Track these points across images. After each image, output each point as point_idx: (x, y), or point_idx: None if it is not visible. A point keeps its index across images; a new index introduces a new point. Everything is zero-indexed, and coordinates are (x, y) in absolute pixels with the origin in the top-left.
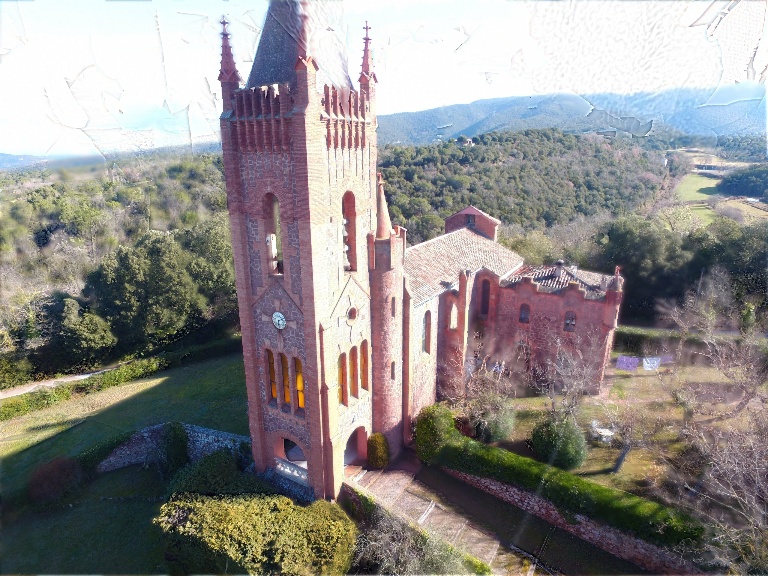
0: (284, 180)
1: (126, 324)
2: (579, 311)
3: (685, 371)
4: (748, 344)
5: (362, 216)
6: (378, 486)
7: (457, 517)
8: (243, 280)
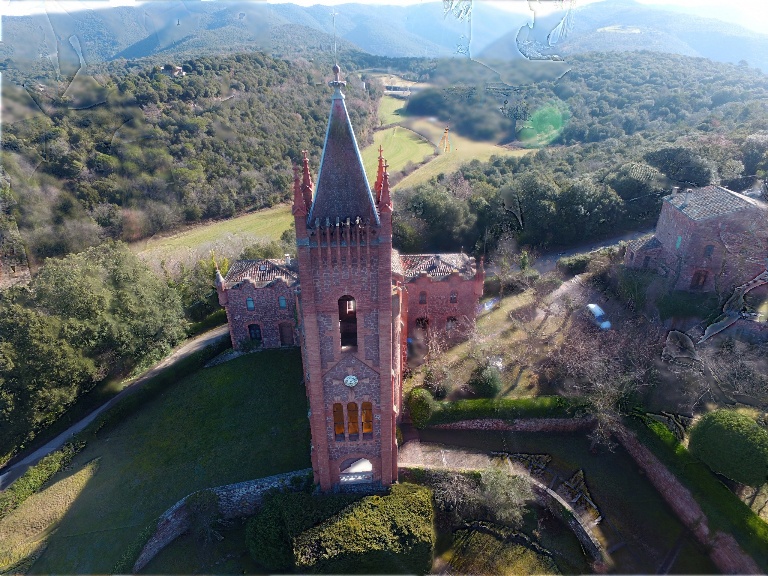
0: (362, 285)
1: (2, 424)
2: (459, 289)
3: (503, 303)
4: (526, 276)
5: None
6: (407, 458)
7: (459, 452)
8: (317, 361)
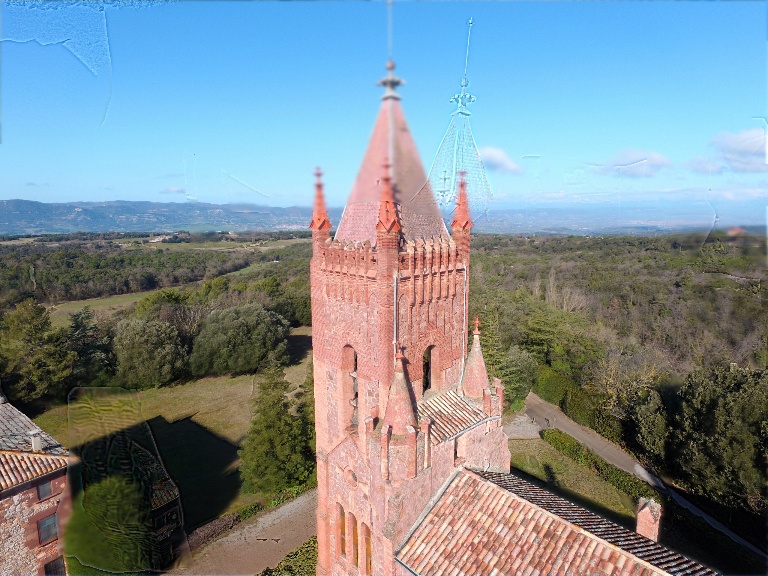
0: None
1: None
2: None
3: None
4: None
5: (366, 381)
6: None
7: None
8: None
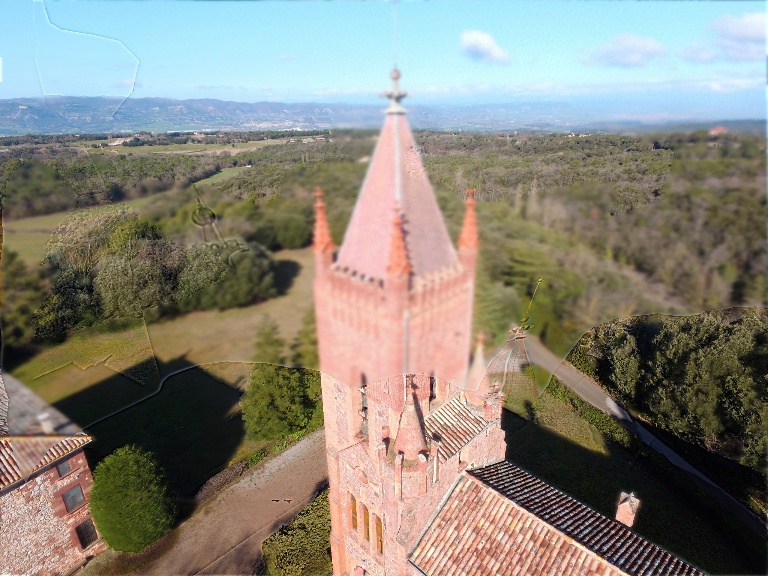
0: None
1: None
2: None
3: None
4: None
5: (376, 403)
6: None
7: None
8: None
